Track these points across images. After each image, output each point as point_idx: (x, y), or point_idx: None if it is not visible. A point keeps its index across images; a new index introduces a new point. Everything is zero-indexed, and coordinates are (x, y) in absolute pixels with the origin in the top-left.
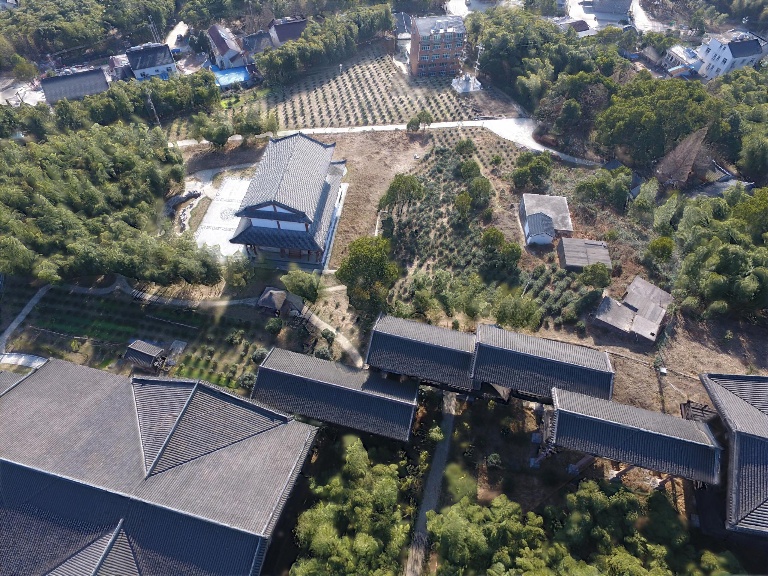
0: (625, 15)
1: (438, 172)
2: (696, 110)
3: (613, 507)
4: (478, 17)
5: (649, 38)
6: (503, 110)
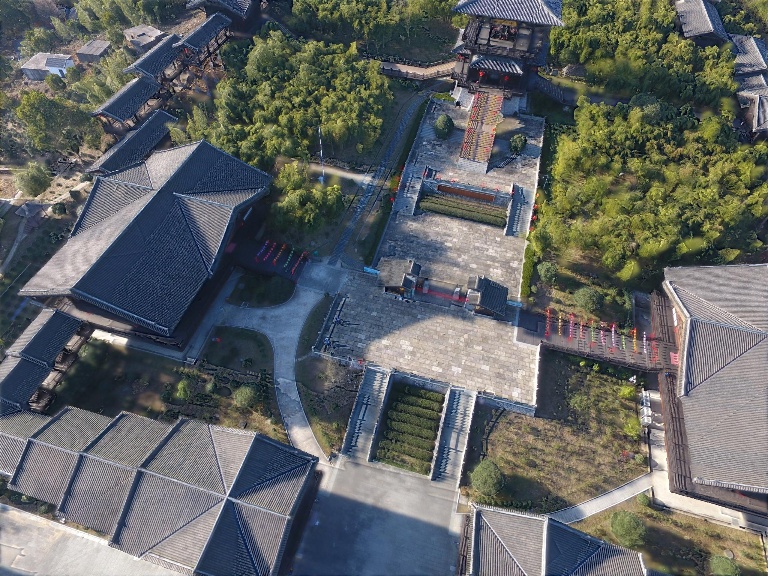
0: None
1: None
2: None
3: (232, 51)
4: None
5: None
6: None
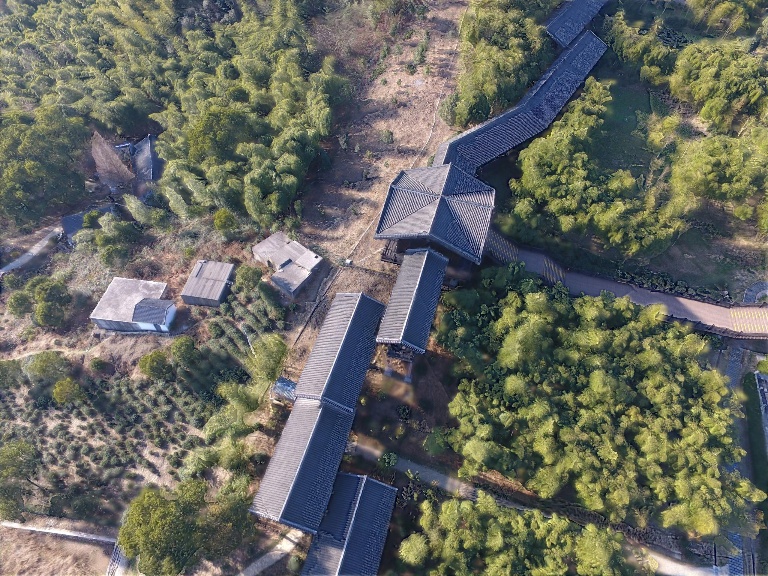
0: None
1: None
2: (45, 129)
3: None
4: None
5: None
6: None
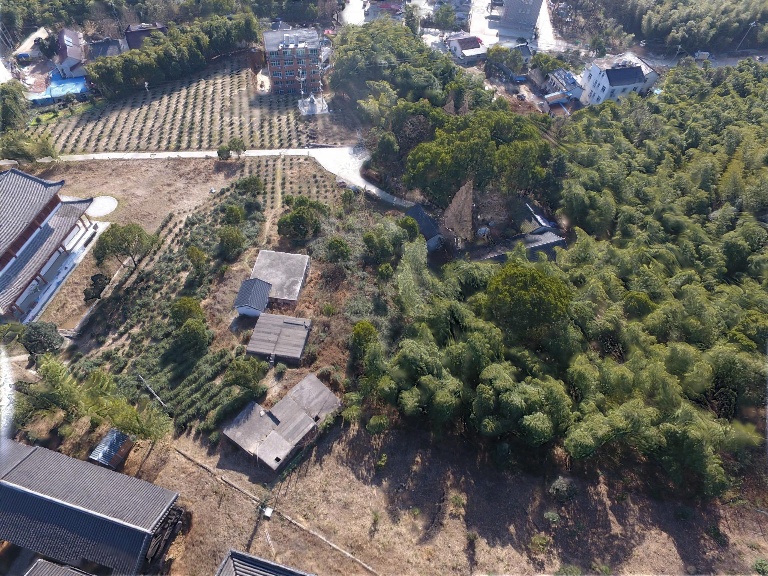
0: (531, 32)
1: (221, 211)
2: (505, 153)
3: None
4: (348, 31)
5: (538, 59)
6: (341, 137)
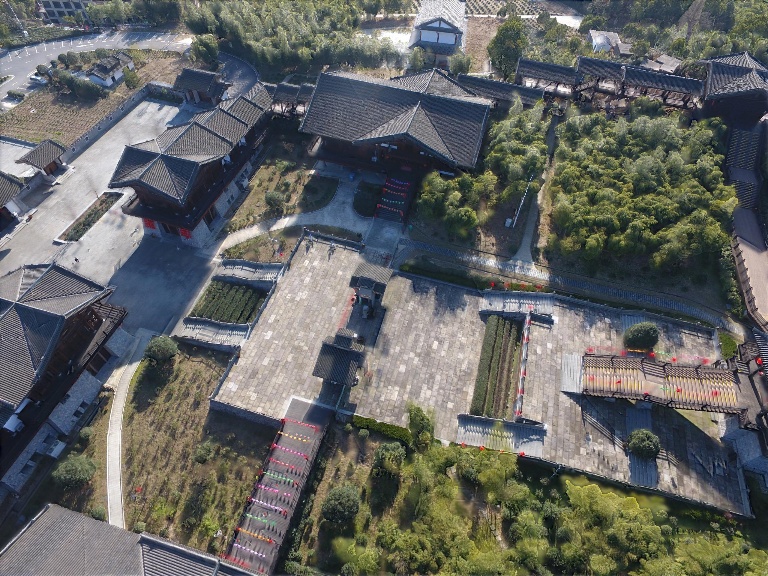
0: None
1: None
2: None
3: (652, 109)
4: None
5: None
6: (563, 11)
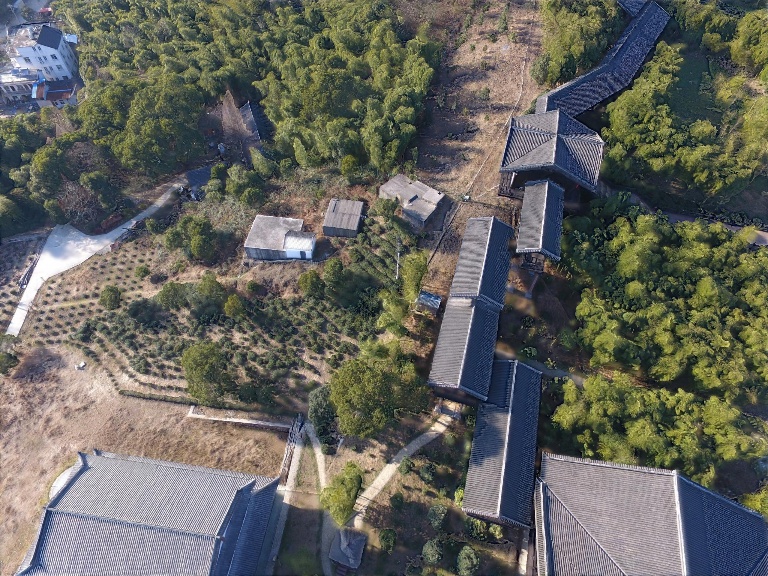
0: None
1: (133, 339)
2: (168, 93)
3: None
4: None
5: None
6: (20, 254)
